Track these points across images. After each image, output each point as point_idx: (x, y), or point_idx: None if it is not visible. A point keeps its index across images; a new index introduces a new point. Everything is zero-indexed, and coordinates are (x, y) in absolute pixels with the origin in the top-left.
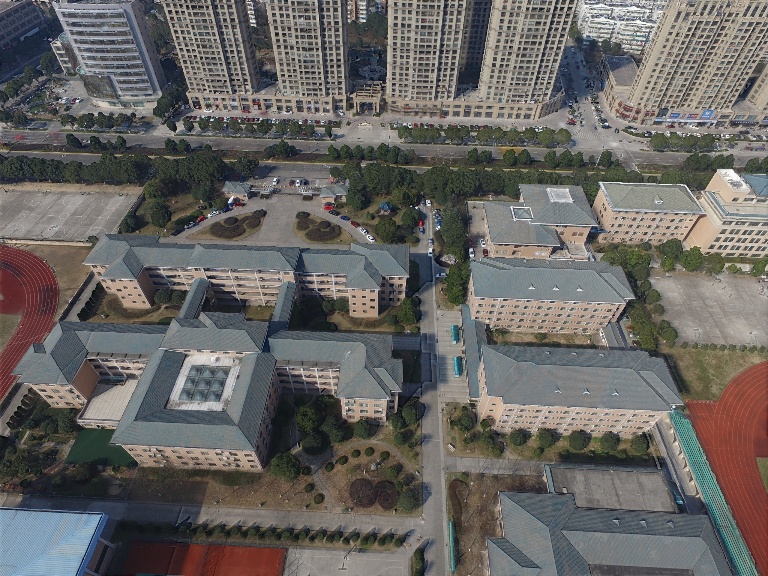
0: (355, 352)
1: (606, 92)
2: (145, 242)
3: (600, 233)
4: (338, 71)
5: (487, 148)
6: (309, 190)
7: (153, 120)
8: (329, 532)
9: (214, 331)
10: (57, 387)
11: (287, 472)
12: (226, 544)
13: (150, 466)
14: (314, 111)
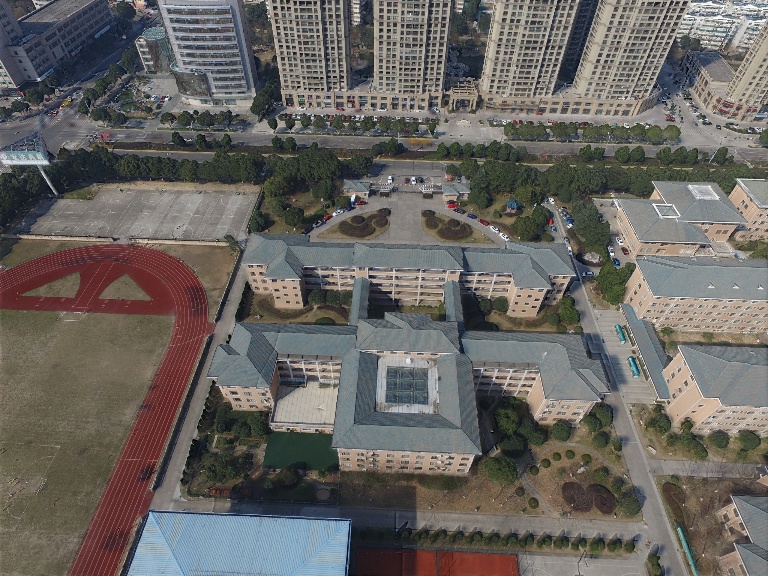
0: (553, 353)
1: (698, 88)
2: (299, 241)
3: (738, 231)
4: (438, 68)
5: (593, 145)
6: (430, 188)
7: (248, 118)
8: (554, 537)
9: (410, 332)
10: (252, 390)
11: (510, 476)
12: (453, 550)
13: (352, 470)
14: (409, 108)
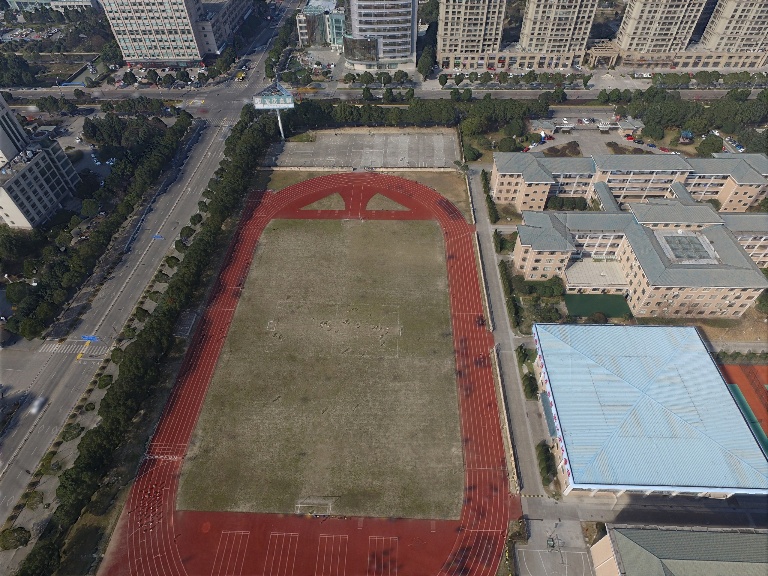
0: None
1: None
2: (540, 156)
3: None
4: (585, 28)
5: None
6: (607, 125)
7: (413, 78)
8: None
9: (681, 208)
10: (555, 256)
11: None
12: (752, 364)
13: (644, 316)
14: (553, 67)
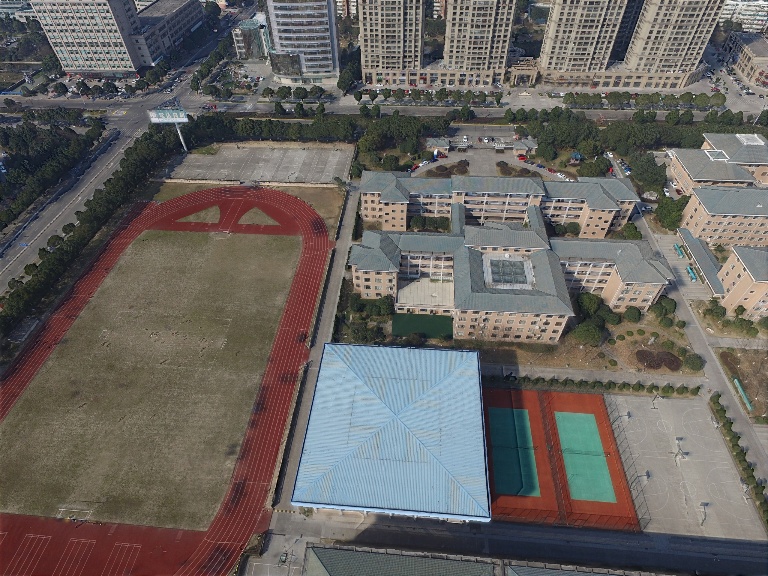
0: (626, 250)
1: (741, 65)
2: (404, 175)
3: None
4: (502, 46)
5: (644, 112)
6: (502, 144)
7: (334, 93)
8: (632, 385)
9: (508, 232)
10: (382, 276)
11: (596, 335)
12: (551, 390)
13: (463, 338)
14: (474, 84)
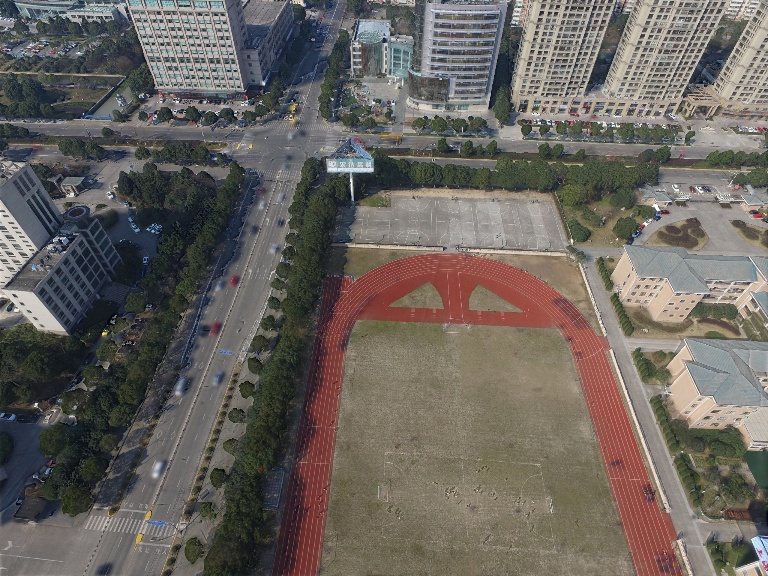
0: None
1: None
2: (684, 254)
3: None
4: (686, 74)
5: None
6: (730, 197)
7: (487, 123)
8: None
9: None
10: (741, 408)
11: None
12: None
13: None
14: (644, 115)
